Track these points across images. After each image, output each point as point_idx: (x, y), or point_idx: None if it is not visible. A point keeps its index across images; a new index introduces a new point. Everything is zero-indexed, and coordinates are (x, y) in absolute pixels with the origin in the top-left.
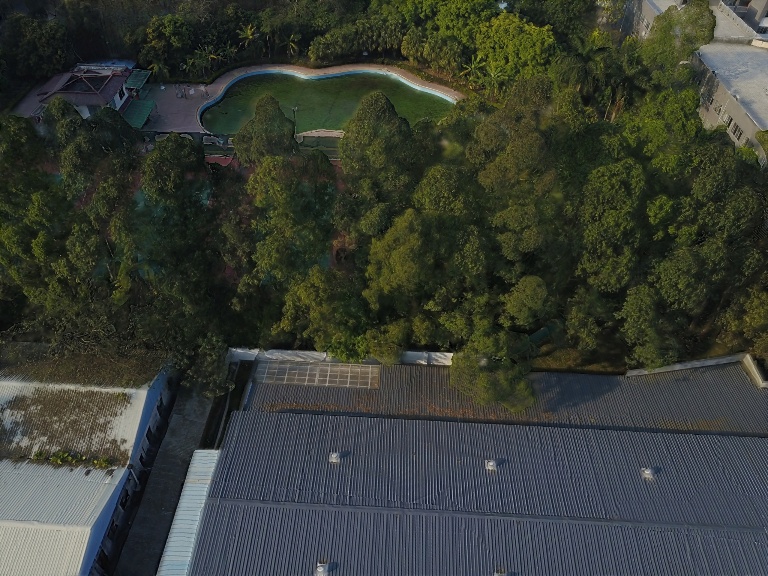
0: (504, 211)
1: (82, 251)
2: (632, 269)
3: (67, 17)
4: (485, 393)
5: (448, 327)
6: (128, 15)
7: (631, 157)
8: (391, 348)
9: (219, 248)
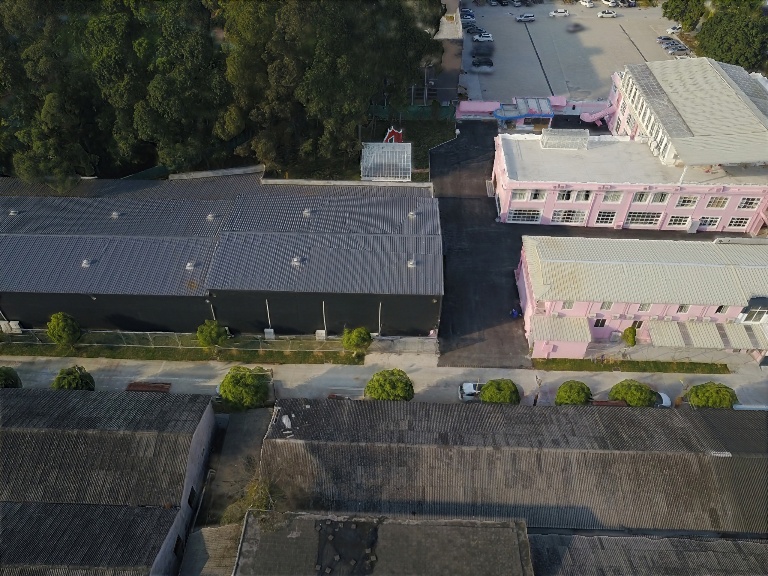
0: (28, 48)
1: None
2: (132, 90)
3: None
4: (26, 174)
5: (18, 138)
6: None
7: (125, 13)
8: None
9: None
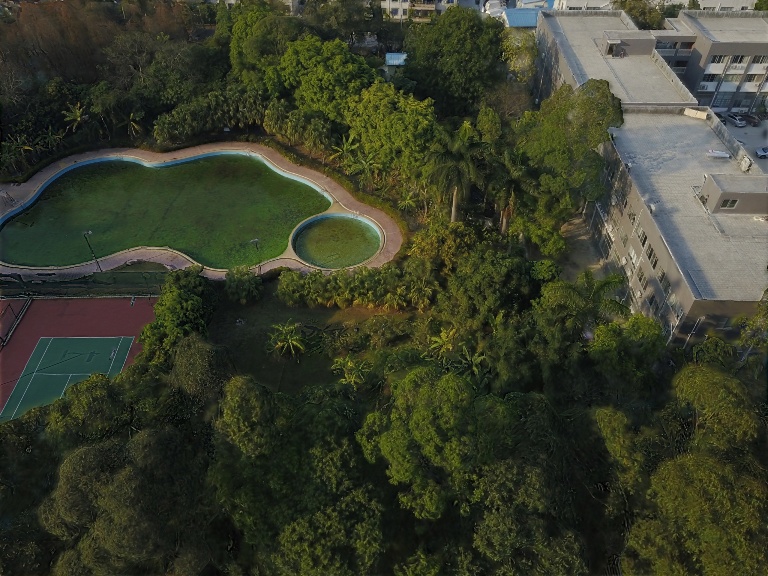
0: None
1: None
2: None
3: None
4: None
5: None
6: None
7: (367, 482)
8: None
9: None
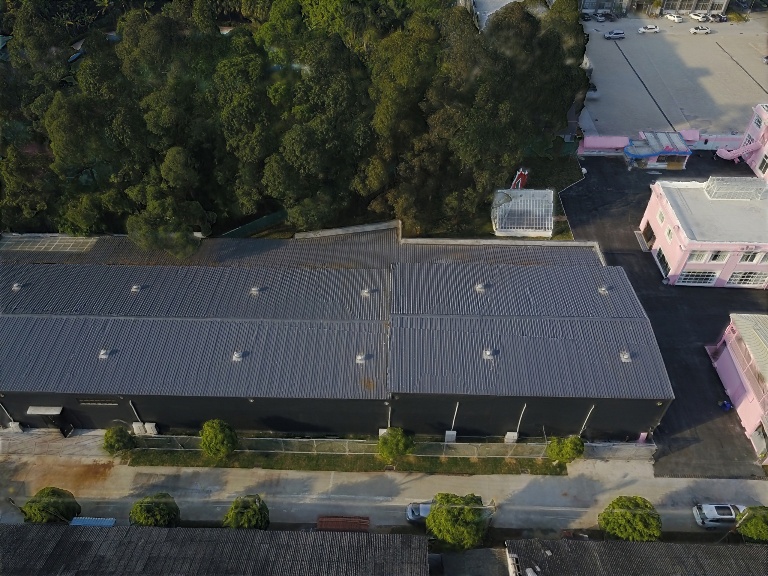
0: (148, 96)
1: None
2: (264, 142)
3: None
4: (145, 240)
5: (130, 195)
6: None
7: (256, 53)
8: (81, 211)
9: None
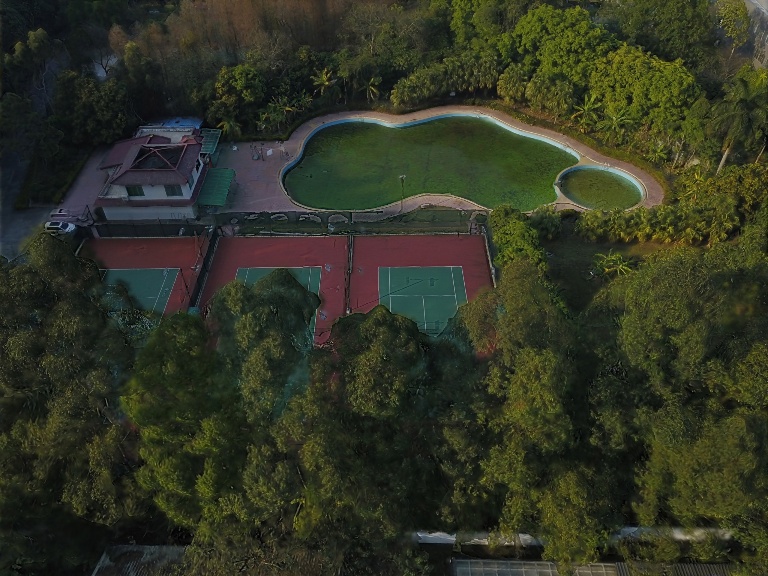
0: None
1: (269, 491)
2: None
3: (127, 75)
4: None
5: (736, 536)
6: (192, 67)
7: None
8: (667, 573)
9: (432, 450)
